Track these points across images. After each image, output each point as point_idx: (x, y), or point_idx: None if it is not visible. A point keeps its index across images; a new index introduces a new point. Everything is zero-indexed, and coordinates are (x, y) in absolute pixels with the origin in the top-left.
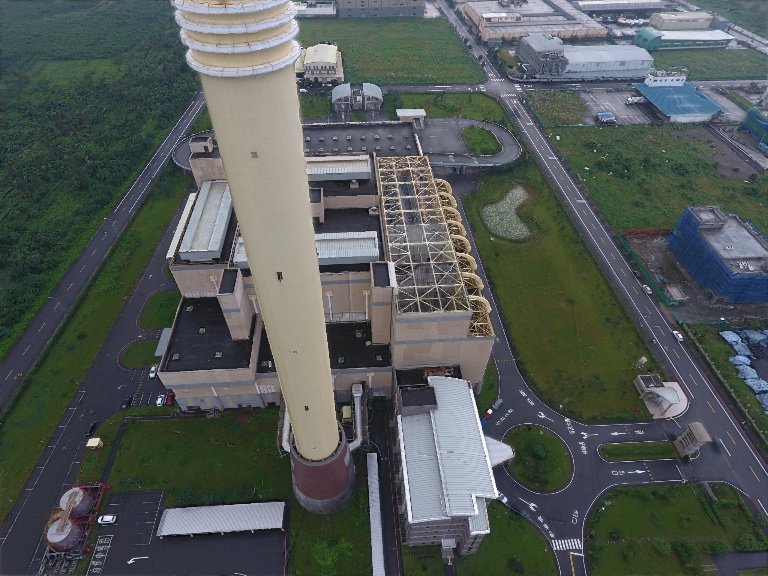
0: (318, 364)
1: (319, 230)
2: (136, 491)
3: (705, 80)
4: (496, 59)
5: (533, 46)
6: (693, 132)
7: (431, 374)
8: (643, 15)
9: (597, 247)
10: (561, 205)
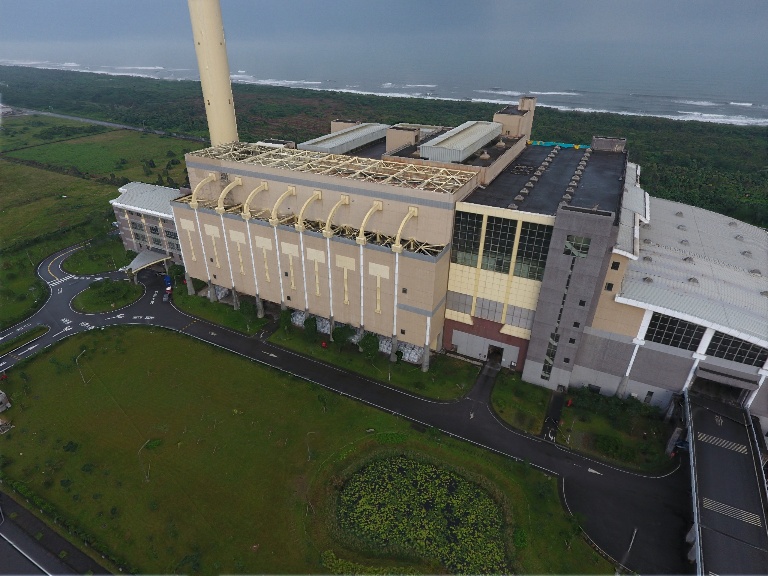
0: None
1: (378, 153)
2: None
3: None
4: None
5: None
6: None
7: None
8: None
9: None
10: None
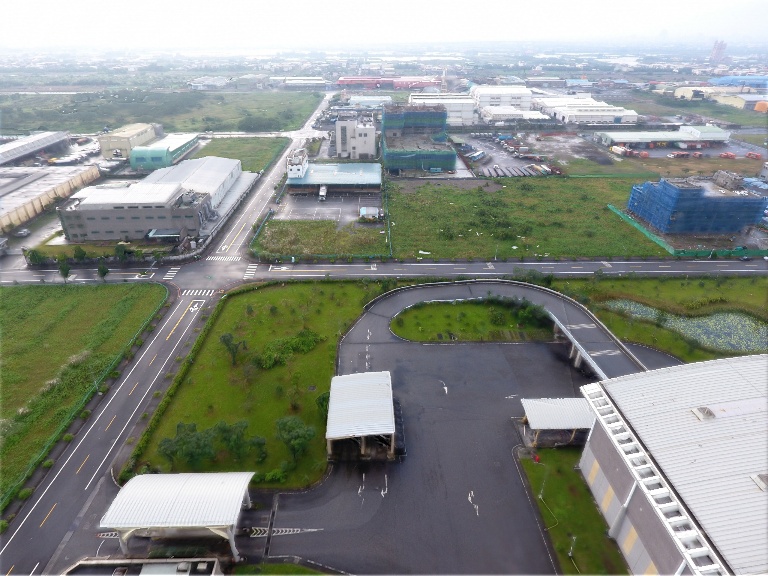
0: None
1: None
2: None
3: (275, 163)
4: (83, 257)
5: (138, 201)
6: (405, 185)
7: None
8: (54, 152)
9: (714, 272)
10: (637, 277)
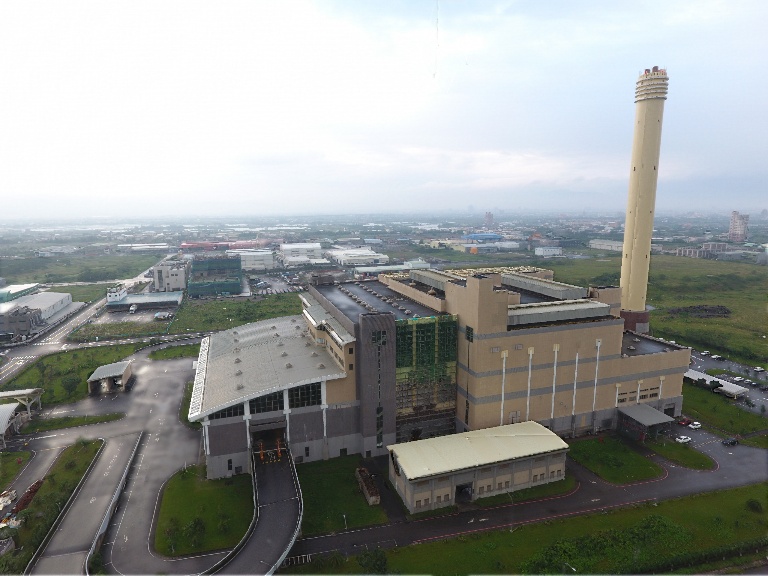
0: None
1: None
2: (754, 413)
3: (103, 297)
4: None
5: None
6: (198, 302)
7: None
8: None
9: None
10: None
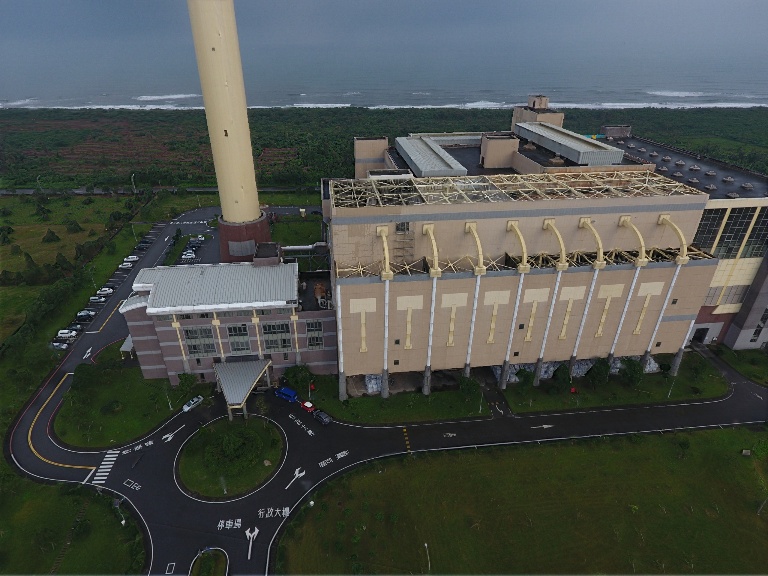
0: (203, 77)
1: (471, 167)
2: None
3: None
4: None
5: None
6: None
7: (317, 286)
8: None
9: None
10: None
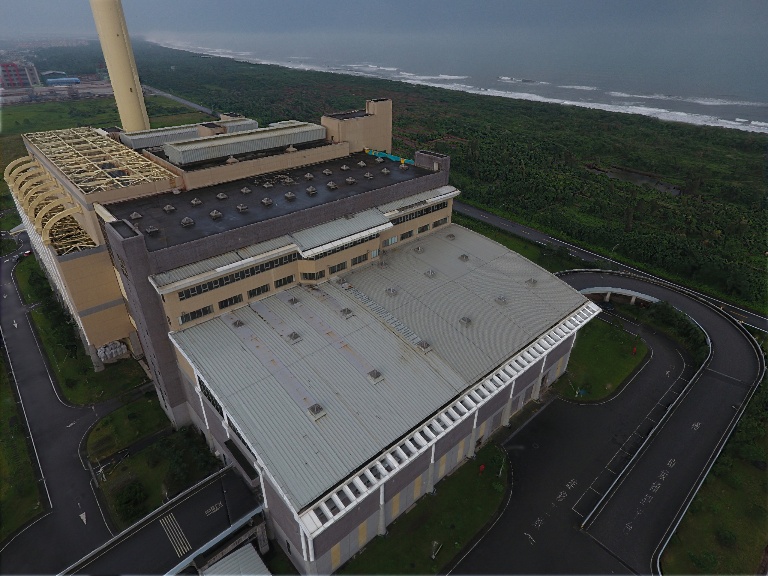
0: None
1: None
2: None
3: None
4: None
5: None
6: None
7: None
8: None
9: None
10: None
